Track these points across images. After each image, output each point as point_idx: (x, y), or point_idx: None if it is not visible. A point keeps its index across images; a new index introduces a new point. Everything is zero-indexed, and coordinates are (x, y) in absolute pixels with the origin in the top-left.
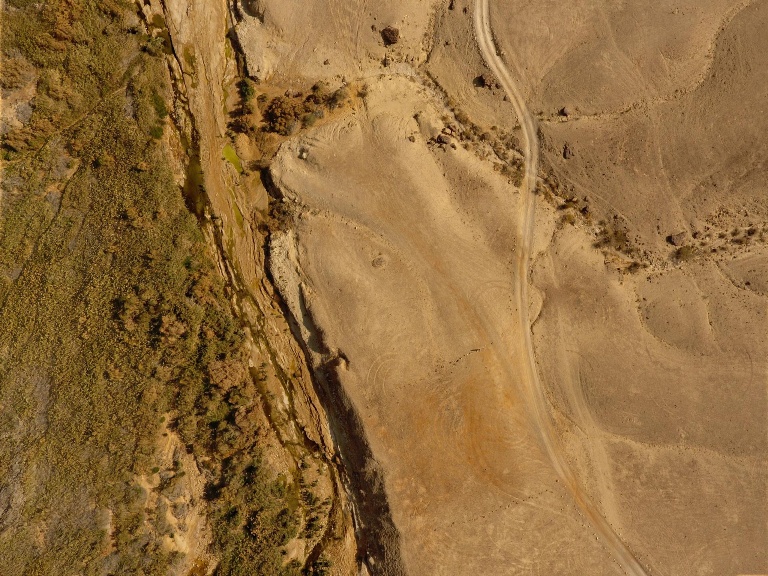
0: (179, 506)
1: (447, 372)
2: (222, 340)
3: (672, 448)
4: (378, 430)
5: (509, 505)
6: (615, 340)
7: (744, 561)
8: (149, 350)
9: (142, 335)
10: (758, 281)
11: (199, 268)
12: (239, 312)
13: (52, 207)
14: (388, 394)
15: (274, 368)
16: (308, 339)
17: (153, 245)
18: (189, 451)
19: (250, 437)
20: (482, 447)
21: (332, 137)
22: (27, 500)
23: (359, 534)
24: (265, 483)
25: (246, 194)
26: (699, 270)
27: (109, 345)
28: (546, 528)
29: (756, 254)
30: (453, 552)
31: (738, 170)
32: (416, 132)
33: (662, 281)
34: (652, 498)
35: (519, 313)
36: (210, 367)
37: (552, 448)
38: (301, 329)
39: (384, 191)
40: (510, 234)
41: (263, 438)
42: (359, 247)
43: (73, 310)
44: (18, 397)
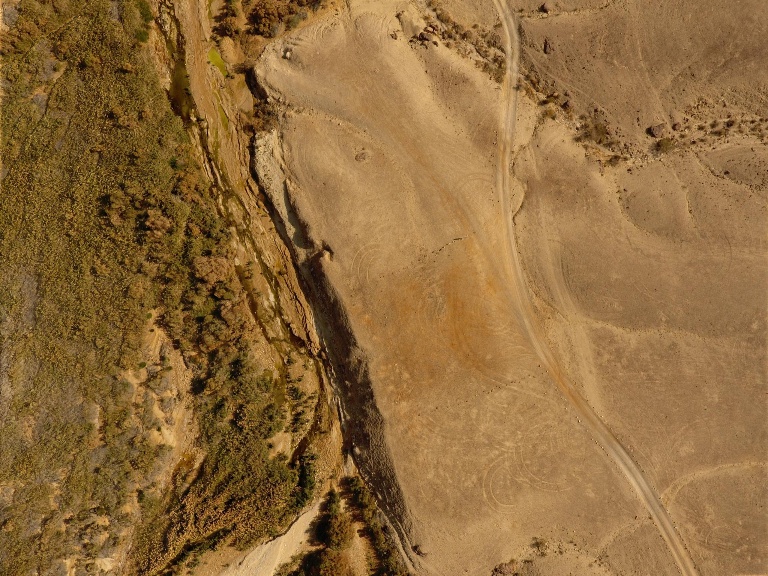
0: (166, 399)
1: (430, 261)
2: (208, 237)
3: (653, 332)
4: (362, 318)
5: (492, 390)
6: (596, 229)
7: (725, 440)
8: (135, 246)
9: (128, 231)
10: (737, 170)
11: (185, 168)
12: (225, 212)
13: (39, 109)
14: (372, 283)
15: (260, 266)
16: (293, 235)
17: (139, 144)
18: (176, 347)
19: (236, 330)
20: (465, 333)
21: (315, 36)
22: (15, 394)
23: (345, 427)
24: (251, 377)
25: (231, 97)
26: (679, 161)
27: (95, 240)
28: (529, 412)
29: (735, 145)
30: (437, 436)
31: (716, 60)
32: (398, 30)
33: (642, 173)
34: (633, 381)
35: (501, 204)
36: (196, 261)
37: (534, 334)
38: (286, 226)
39: (367, 87)
40: (492, 128)
41: (249, 332)
42: (343, 142)
43: (60, 208)
44: (6, 294)
